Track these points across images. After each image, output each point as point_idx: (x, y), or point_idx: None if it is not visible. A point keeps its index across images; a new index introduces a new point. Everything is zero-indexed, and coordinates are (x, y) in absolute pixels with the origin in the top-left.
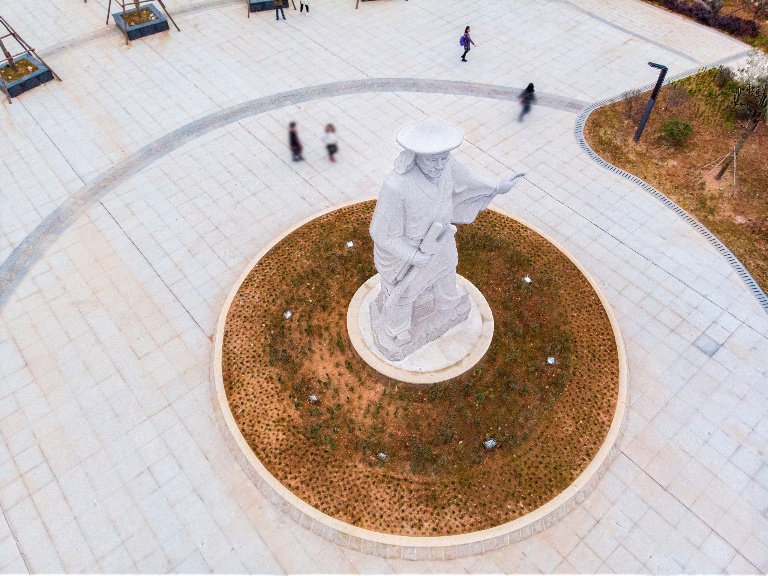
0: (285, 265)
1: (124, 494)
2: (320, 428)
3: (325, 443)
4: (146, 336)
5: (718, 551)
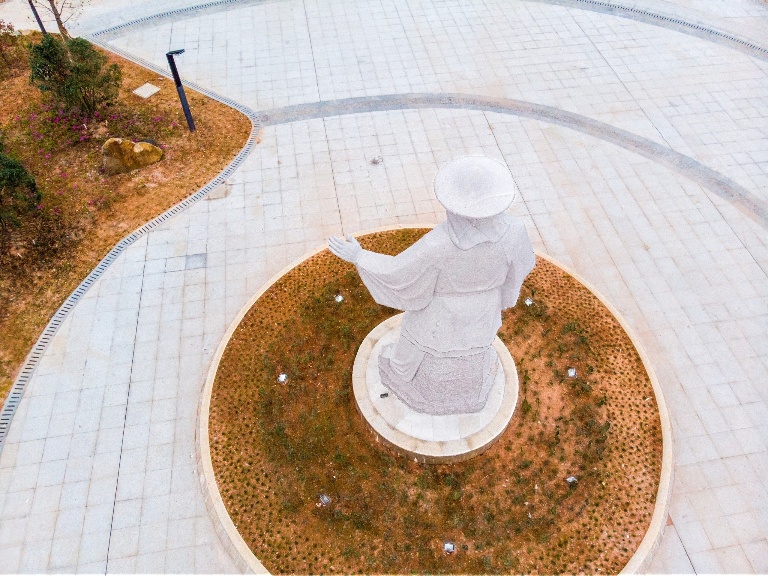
0: (552, 570)
1: (764, 393)
2: (574, 347)
3: (573, 334)
4: (761, 573)
5: (344, 178)
